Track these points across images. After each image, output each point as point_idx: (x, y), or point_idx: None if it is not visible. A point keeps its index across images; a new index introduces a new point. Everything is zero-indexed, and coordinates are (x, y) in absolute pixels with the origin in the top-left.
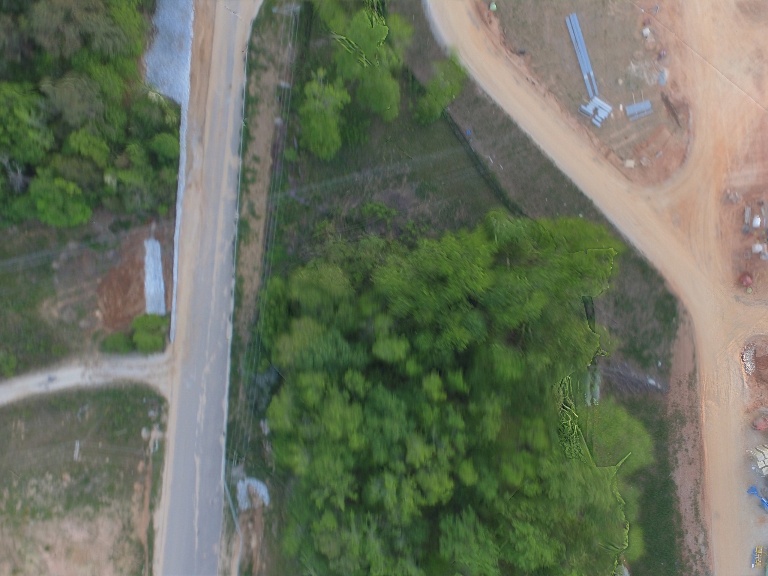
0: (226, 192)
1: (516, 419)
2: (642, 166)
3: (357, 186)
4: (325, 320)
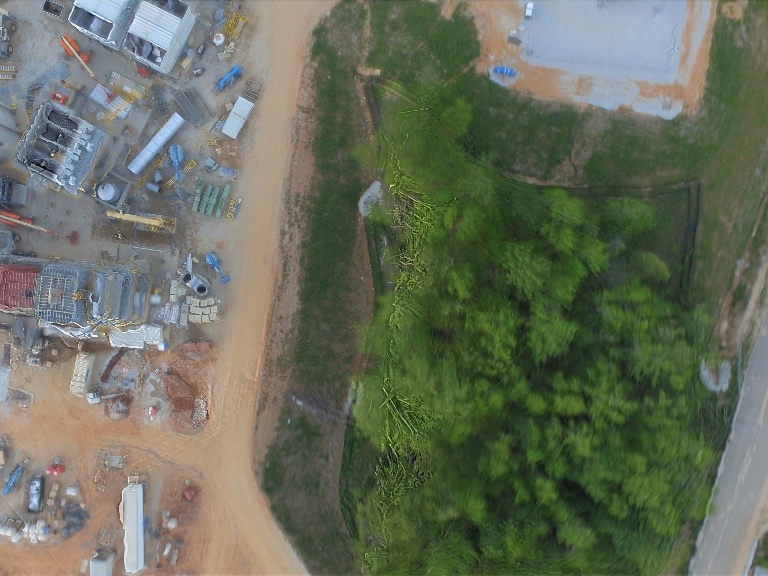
0: None
1: (477, 451)
2: None
3: None
4: None
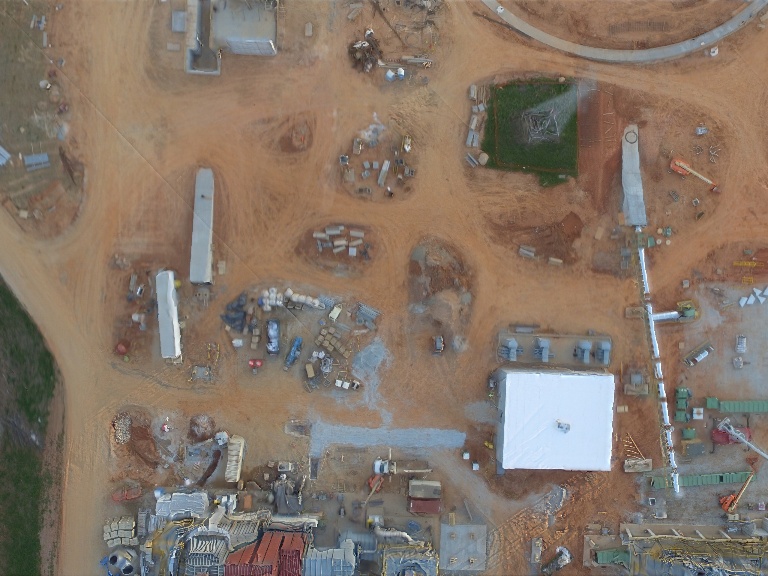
0: None
1: None
2: (35, 218)
3: None
4: None
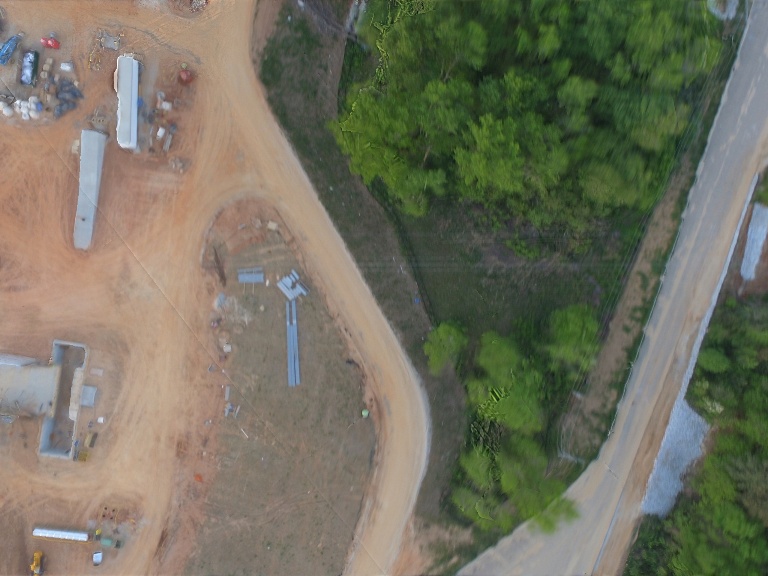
0: (666, 304)
1: None
2: (262, 220)
3: (537, 278)
4: (625, 145)
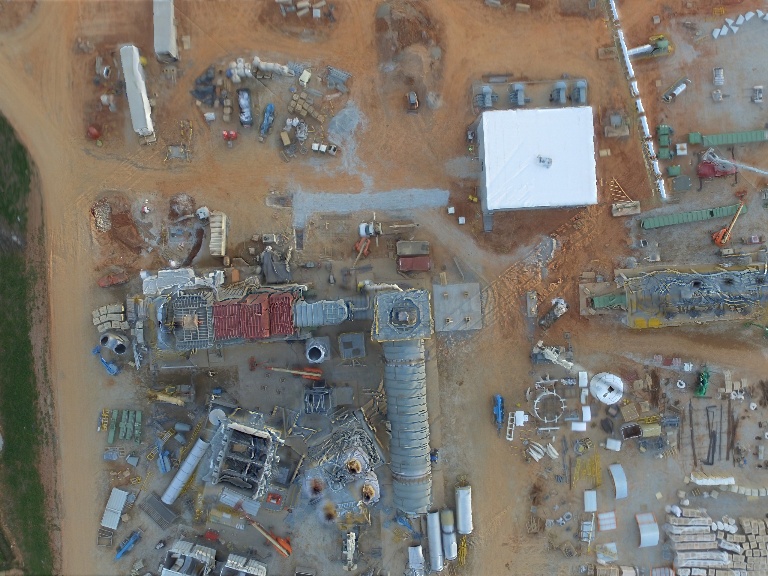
0: None
1: None
2: None
3: None
4: None
